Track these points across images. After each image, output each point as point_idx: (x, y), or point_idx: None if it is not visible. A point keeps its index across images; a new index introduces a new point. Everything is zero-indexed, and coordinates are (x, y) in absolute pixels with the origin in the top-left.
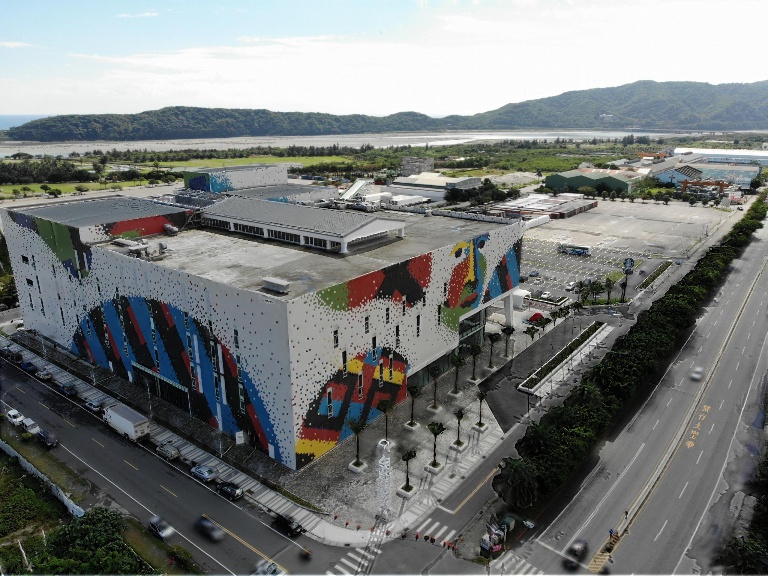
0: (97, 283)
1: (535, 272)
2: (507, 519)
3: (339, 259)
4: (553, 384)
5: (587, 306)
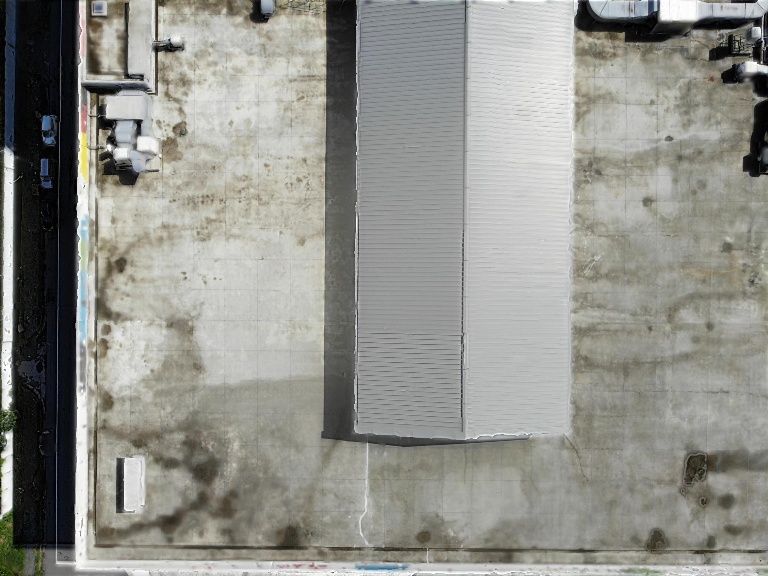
0: None
1: None
2: None
3: (324, 440)
4: None
5: None
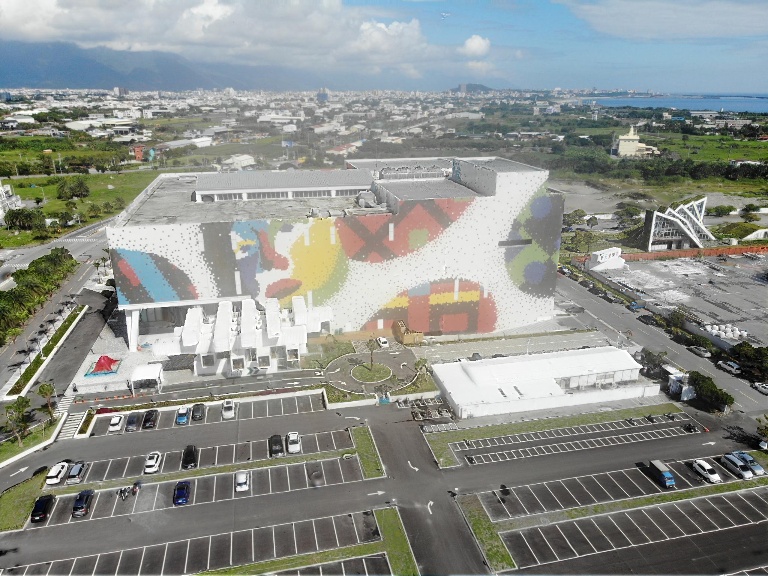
0: None
1: (180, 485)
2: None
3: None
4: (62, 318)
5: (37, 424)
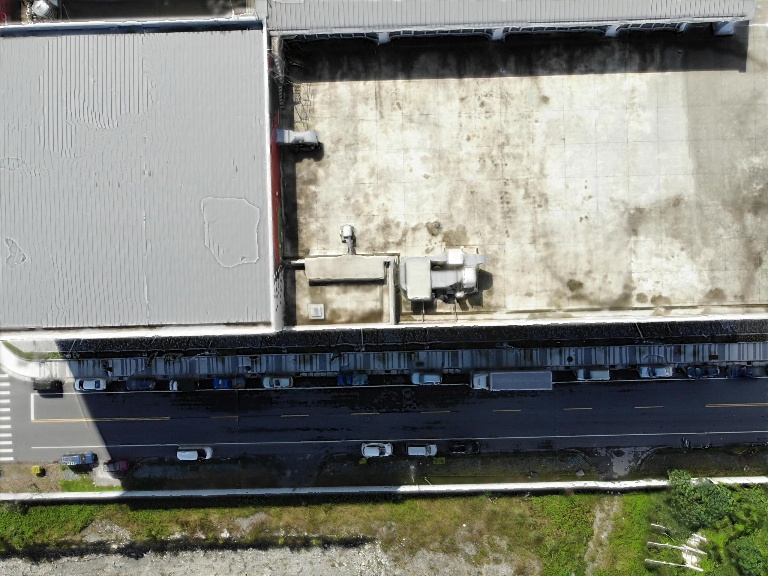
0: None
1: None
2: None
3: (749, 70)
4: None
5: None
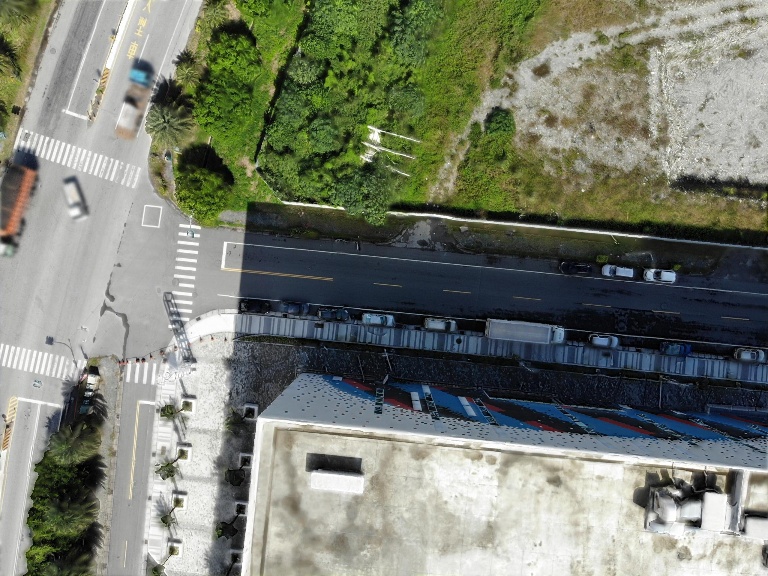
0: (763, 450)
1: None
2: (85, 410)
3: None
4: None
5: None
